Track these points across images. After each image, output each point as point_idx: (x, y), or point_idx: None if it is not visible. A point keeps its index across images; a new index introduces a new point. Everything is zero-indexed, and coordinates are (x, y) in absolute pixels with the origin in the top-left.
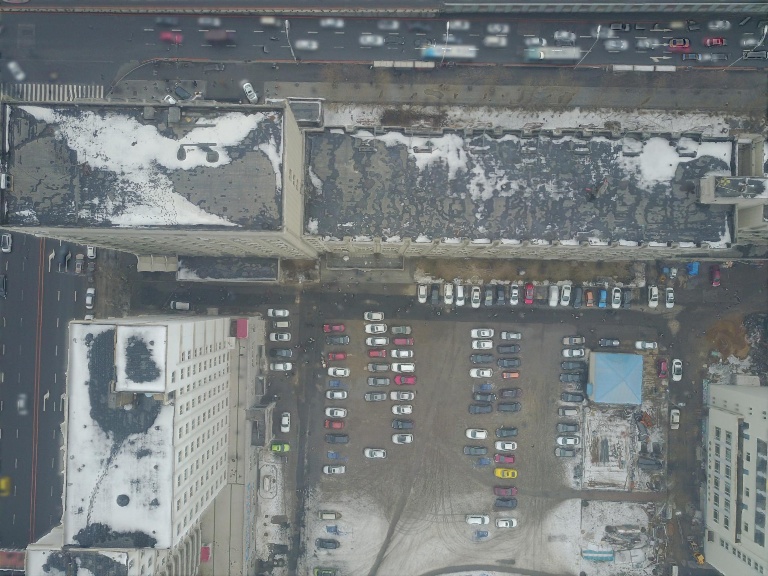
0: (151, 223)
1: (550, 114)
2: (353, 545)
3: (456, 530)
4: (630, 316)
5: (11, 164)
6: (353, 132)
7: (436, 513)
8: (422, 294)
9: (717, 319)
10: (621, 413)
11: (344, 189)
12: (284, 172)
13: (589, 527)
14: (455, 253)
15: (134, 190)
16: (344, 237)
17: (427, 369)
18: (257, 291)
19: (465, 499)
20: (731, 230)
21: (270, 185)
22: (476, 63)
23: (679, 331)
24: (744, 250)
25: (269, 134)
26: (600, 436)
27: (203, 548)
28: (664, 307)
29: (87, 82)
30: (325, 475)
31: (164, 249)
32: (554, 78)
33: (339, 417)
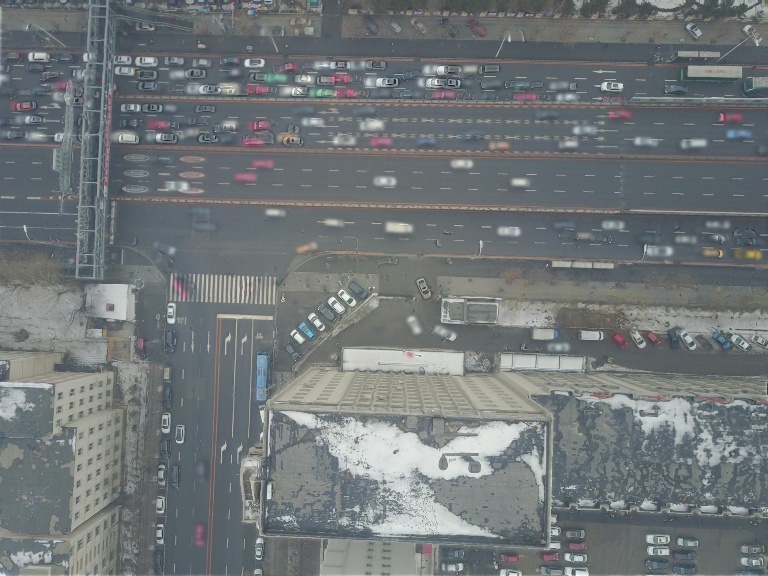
0: (412, 532)
1: (730, 315)
2: None
3: None
4: None
5: (272, 469)
6: (579, 396)
7: None
8: None
9: None
10: None
11: (568, 451)
12: (550, 487)
13: None
14: None
15: (395, 499)
16: (570, 504)
17: (600, 573)
18: None
19: None
20: None
21: (532, 497)
22: (653, 260)
23: None
24: None
25: (532, 445)
26: None
27: None
28: None
29: (260, 273)
30: None
31: None
32: (734, 278)
33: None
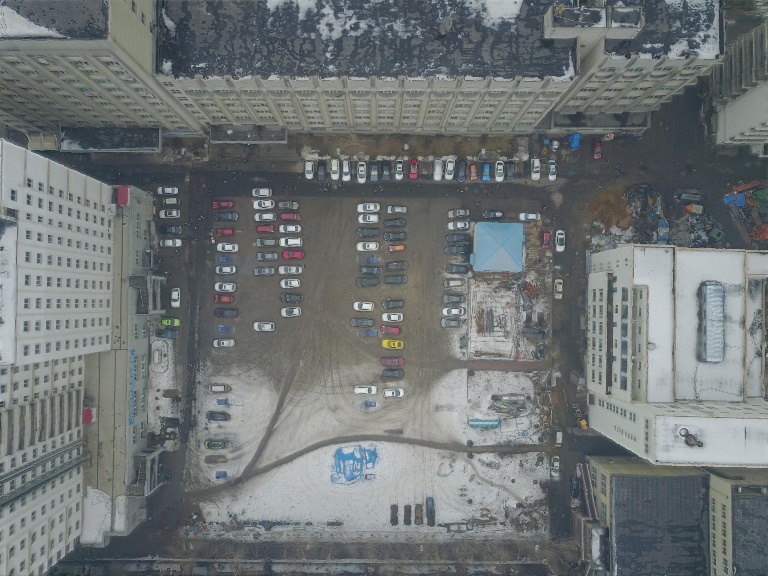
0: None
1: None
2: (244, 417)
3: (345, 401)
4: (514, 189)
5: None
6: None
7: (325, 385)
8: (308, 170)
9: (599, 191)
10: (506, 284)
11: (197, 31)
12: None
13: (475, 396)
14: (335, 124)
15: None
16: (195, 75)
17: (315, 244)
18: (147, 170)
19: (353, 371)
20: (574, 64)
21: None
22: None
23: (562, 203)
24: (622, 119)
25: None
26: (485, 307)
27: (86, 410)
28: (547, 180)
29: None
30: (215, 349)
31: (40, 113)
32: None
33: (228, 292)
